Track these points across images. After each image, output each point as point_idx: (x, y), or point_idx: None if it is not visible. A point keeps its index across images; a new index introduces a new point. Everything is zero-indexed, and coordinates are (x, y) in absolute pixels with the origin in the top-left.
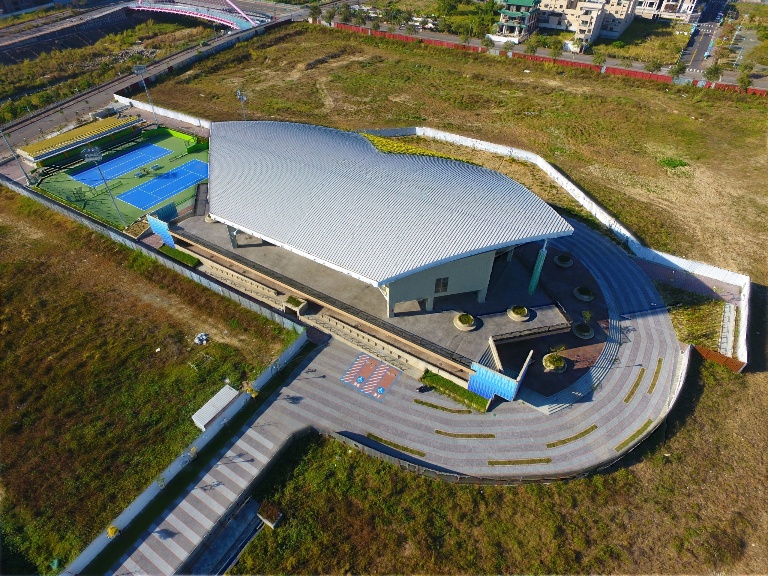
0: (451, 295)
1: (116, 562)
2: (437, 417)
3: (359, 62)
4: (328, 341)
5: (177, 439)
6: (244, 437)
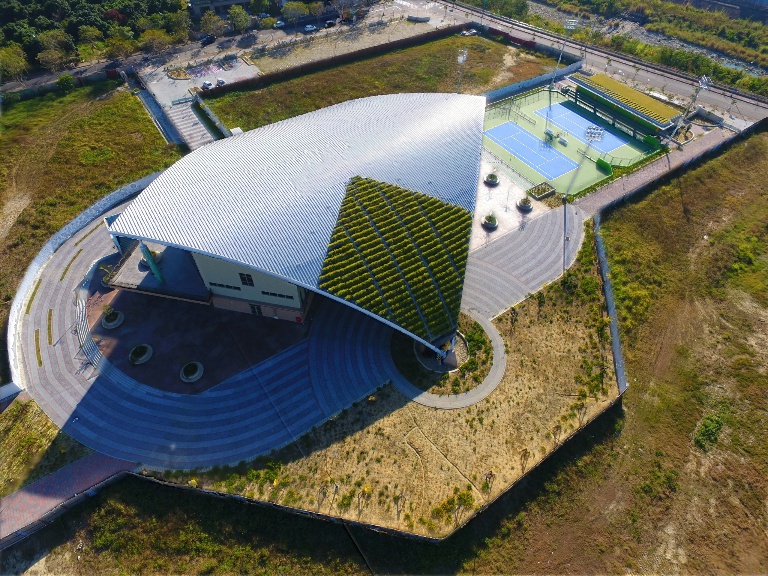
0: None
1: None
2: None
3: None
4: None
5: None
6: None
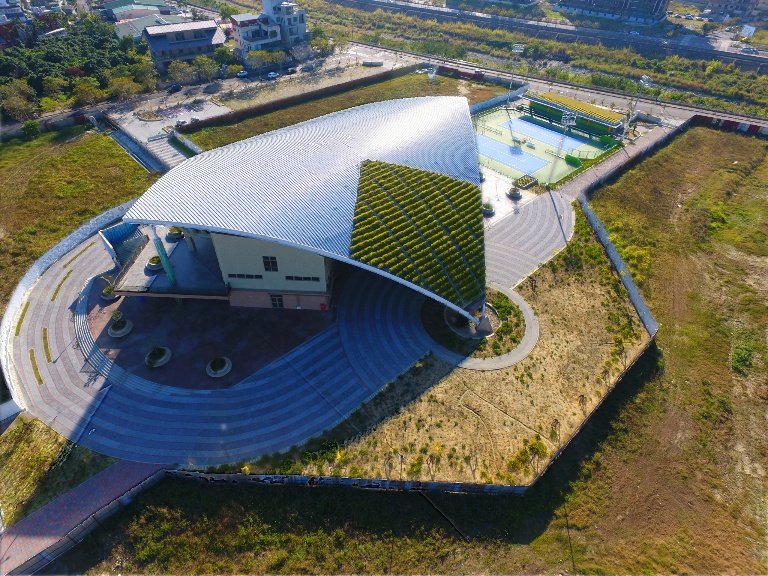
0: None
1: None
2: None
3: None
4: None
5: None
6: None
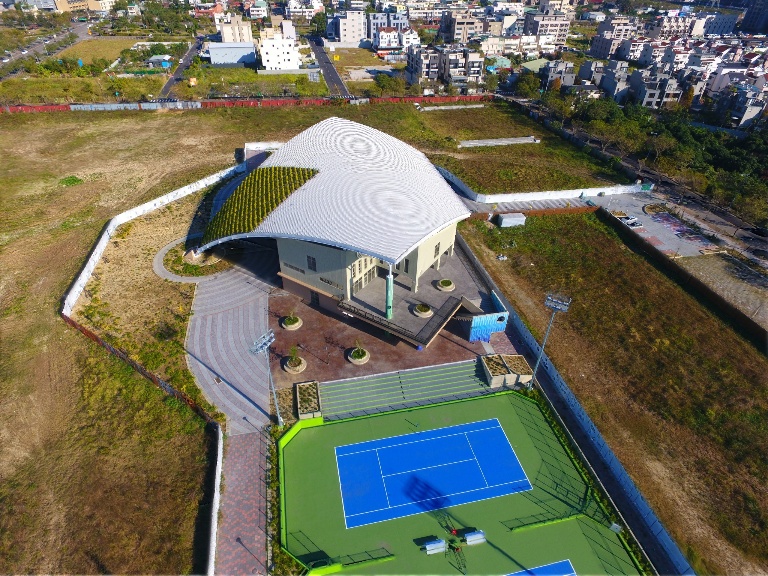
0: None
1: None
2: None
3: None
4: None
5: None
6: None
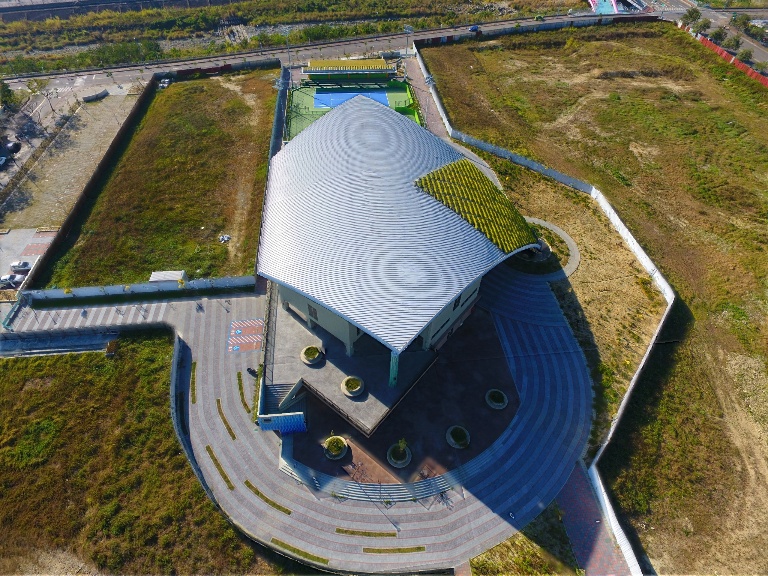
0: (322, 327)
1: (63, 307)
2: (231, 393)
3: (665, 91)
4: (261, 295)
5: (143, 278)
6: (159, 304)
